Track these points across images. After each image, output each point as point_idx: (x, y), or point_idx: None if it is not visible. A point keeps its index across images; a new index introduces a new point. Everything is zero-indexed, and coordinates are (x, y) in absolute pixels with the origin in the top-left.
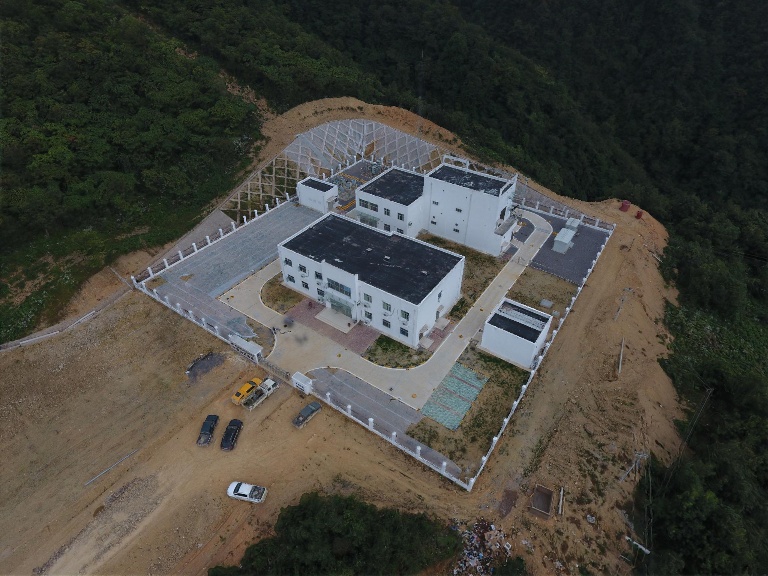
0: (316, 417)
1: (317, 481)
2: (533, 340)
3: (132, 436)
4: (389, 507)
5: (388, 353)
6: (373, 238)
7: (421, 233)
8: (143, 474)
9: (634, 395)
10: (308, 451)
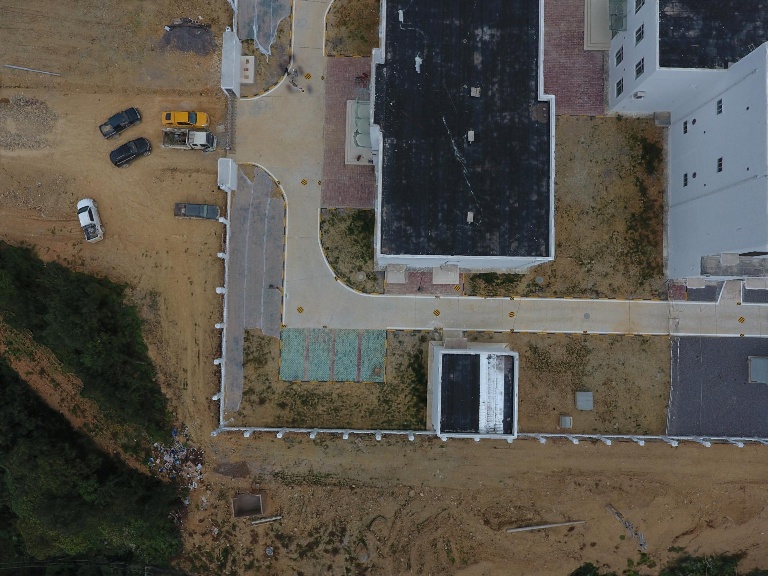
0: (205, 222)
1: (139, 277)
2: (453, 426)
3: (68, 54)
4: (154, 363)
5: (346, 239)
6: (517, 74)
7: (655, 118)
8: (51, 105)
9: (472, 559)
10: (163, 244)
